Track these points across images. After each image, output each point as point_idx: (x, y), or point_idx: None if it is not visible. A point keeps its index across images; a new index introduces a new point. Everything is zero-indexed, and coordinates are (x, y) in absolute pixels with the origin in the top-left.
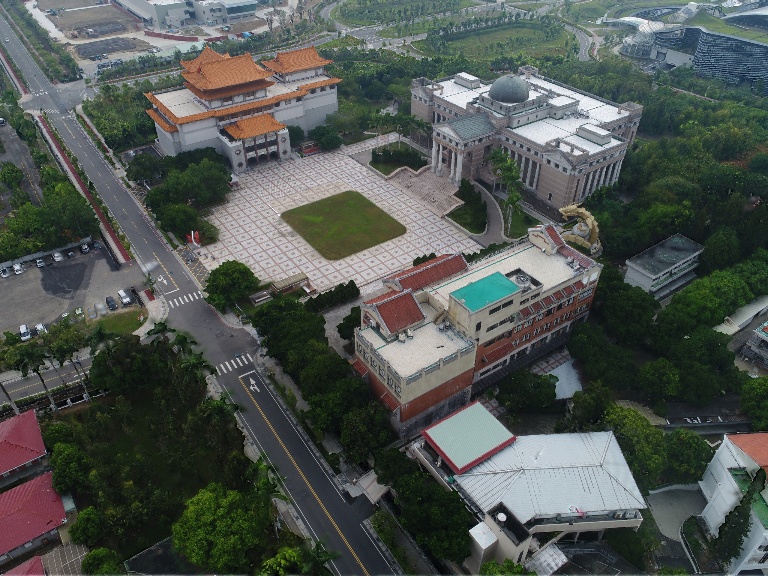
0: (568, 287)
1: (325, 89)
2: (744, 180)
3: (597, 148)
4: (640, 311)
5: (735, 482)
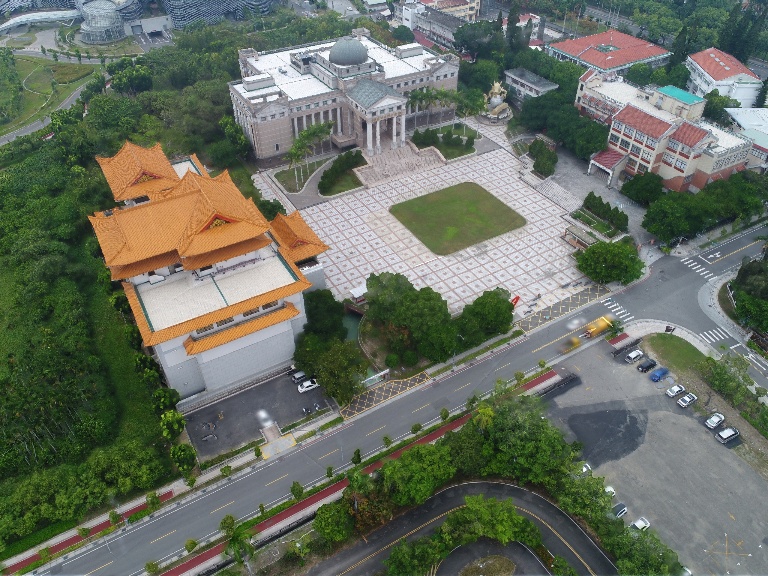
0: None
1: None
2: None
3: (428, 56)
4: None
5: (746, 84)
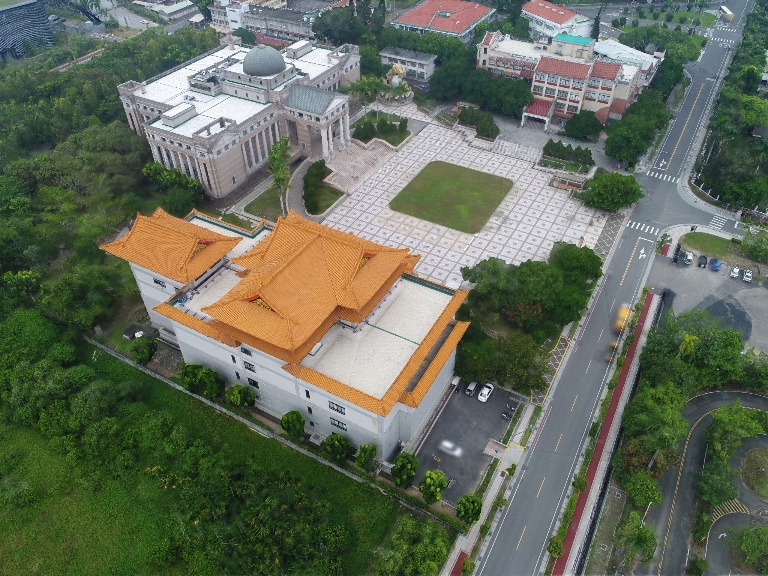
0: None
1: None
2: None
3: (319, 51)
4: None
5: None
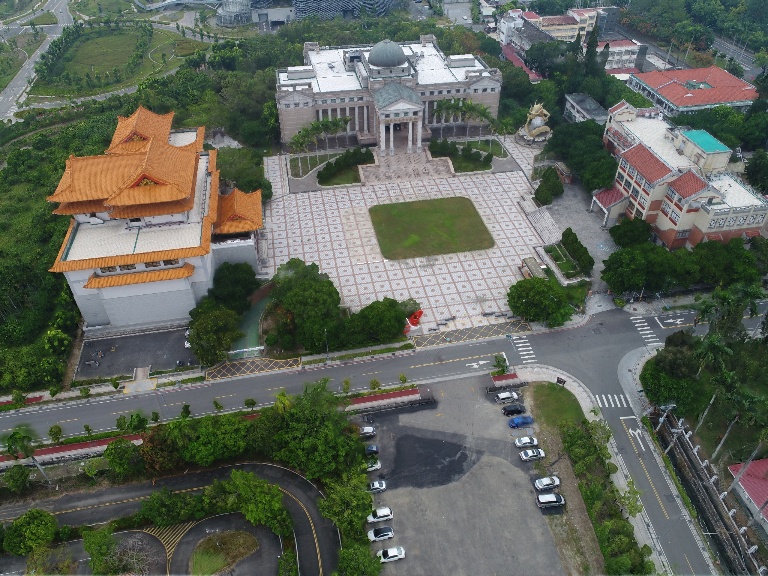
0: None
1: None
2: (560, 46)
3: (478, 68)
4: None
5: None
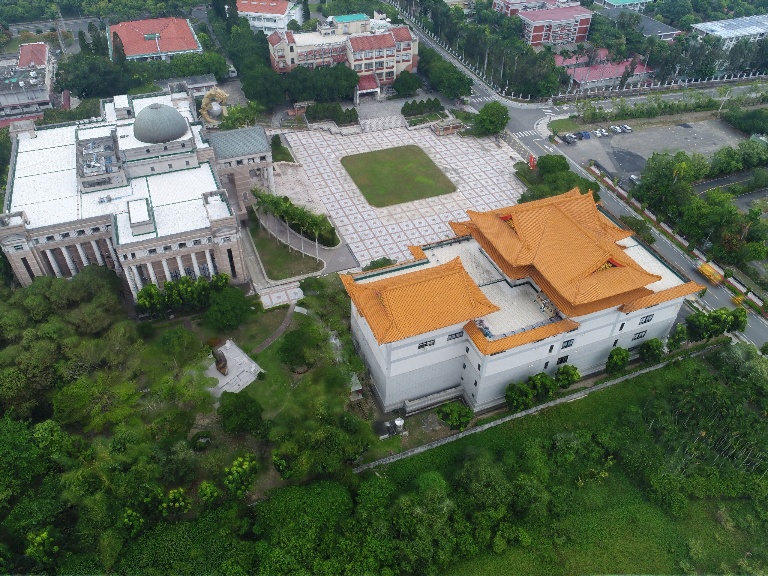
0: None
1: None
2: None
3: (140, 102)
4: None
5: None
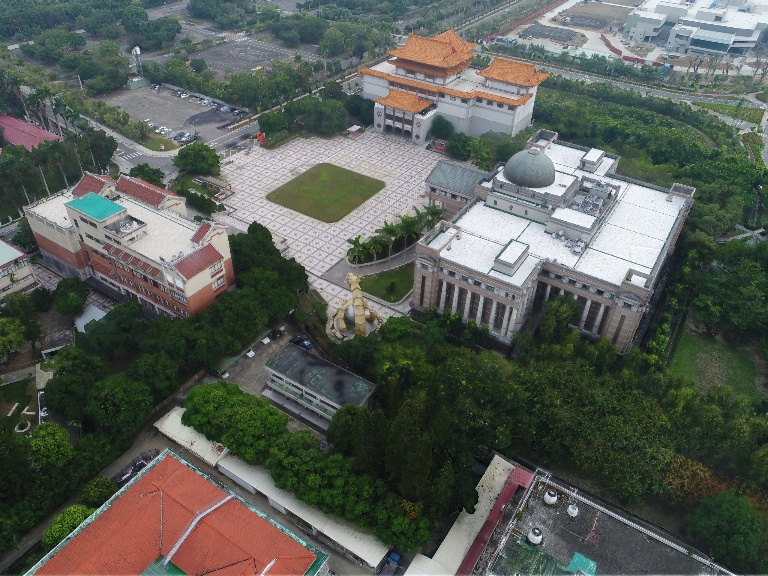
0: (149, 265)
1: (503, 106)
2: None
3: (481, 266)
4: (154, 333)
5: None
